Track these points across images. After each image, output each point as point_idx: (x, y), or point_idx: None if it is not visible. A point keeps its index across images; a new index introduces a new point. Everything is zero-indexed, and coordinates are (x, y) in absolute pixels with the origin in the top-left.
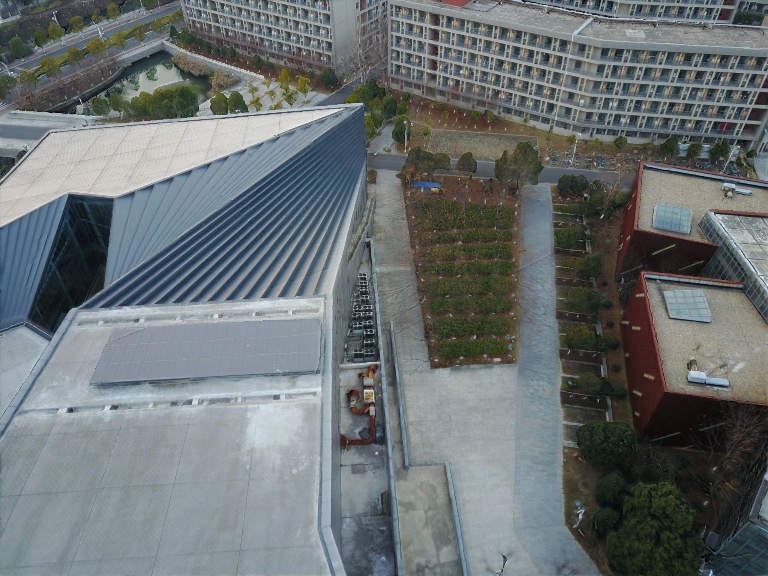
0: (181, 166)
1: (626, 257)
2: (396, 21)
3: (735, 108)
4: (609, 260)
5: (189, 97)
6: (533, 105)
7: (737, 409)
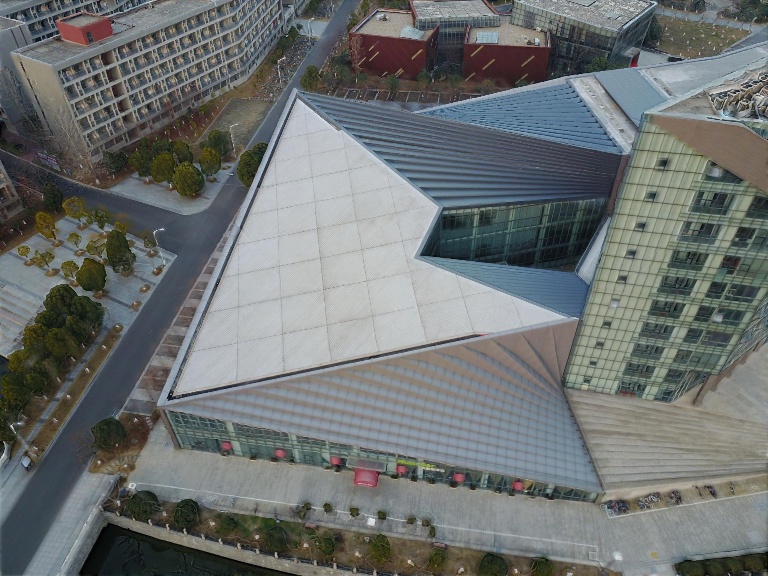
0: (384, 179)
1: (427, 61)
2: (67, 87)
3: (274, 7)
4: (404, 83)
5: (74, 292)
6: (210, 79)
7: (554, 36)
